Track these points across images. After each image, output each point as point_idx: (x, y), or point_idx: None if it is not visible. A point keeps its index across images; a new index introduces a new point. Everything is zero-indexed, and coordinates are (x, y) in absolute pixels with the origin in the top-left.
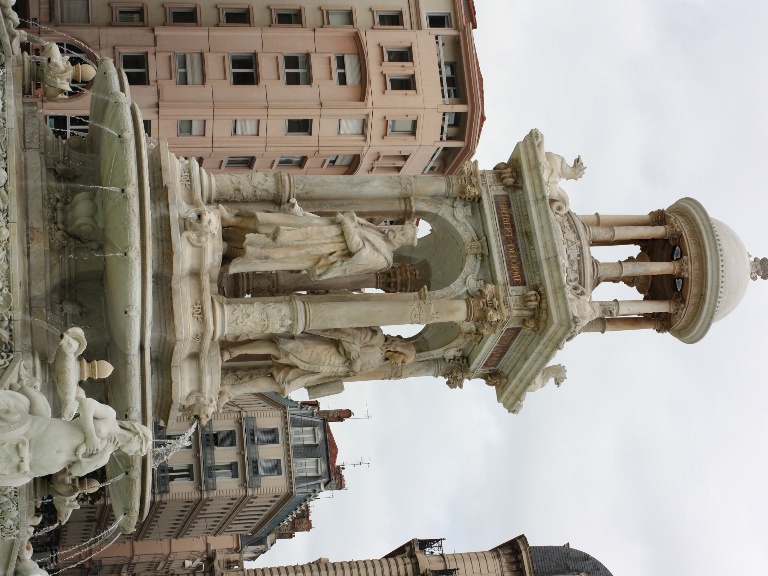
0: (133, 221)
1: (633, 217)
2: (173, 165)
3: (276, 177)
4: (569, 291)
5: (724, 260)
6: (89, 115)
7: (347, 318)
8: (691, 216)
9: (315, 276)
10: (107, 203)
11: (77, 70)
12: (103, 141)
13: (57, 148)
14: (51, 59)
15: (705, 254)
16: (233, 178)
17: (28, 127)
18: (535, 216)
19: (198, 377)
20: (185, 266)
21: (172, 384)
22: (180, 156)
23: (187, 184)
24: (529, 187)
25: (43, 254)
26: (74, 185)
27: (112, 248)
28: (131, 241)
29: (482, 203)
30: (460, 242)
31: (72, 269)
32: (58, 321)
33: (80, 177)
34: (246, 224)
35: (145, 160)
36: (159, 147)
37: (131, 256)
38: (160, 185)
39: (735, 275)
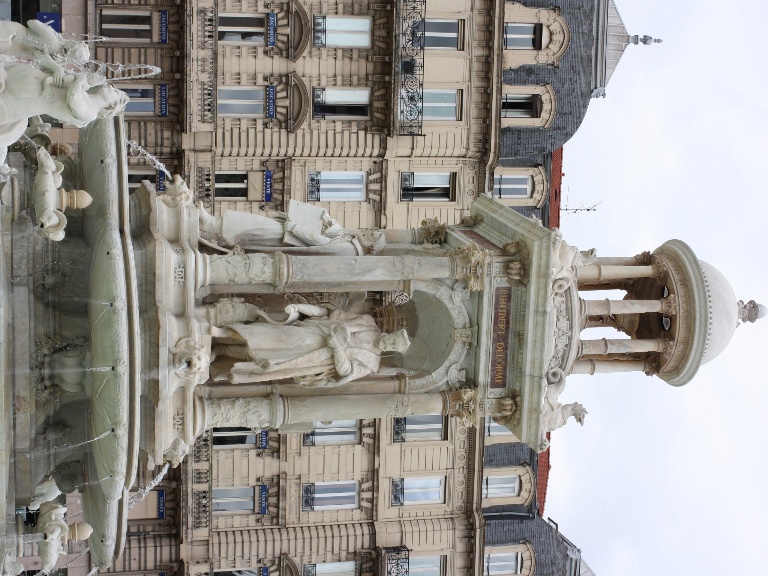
0: (121, 455)
1: (636, 272)
2: (168, 264)
3: (275, 268)
4: (545, 402)
5: (709, 344)
6: (82, 141)
7: (324, 419)
8: (692, 292)
9: (299, 383)
10: (96, 400)
11: (72, 203)
12: (96, 309)
13: (46, 253)
14: (44, 226)
15: (692, 342)
16: (230, 268)
17: (16, 250)
18: (531, 328)
19: (174, 442)
20: (170, 395)
21: (148, 461)
22: (177, 177)
23: (181, 281)
24: (533, 294)
25: (29, 424)
26: (63, 290)
27: (98, 444)
28: (118, 469)
29: (482, 293)
30: (452, 320)
31: (57, 407)
32: (41, 451)
33: (69, 280)
34: (237, 337)
35: (138, 387)
36: (155, 249)
37: (117, 479)
38: (152, 293)
39: (716, 351)
